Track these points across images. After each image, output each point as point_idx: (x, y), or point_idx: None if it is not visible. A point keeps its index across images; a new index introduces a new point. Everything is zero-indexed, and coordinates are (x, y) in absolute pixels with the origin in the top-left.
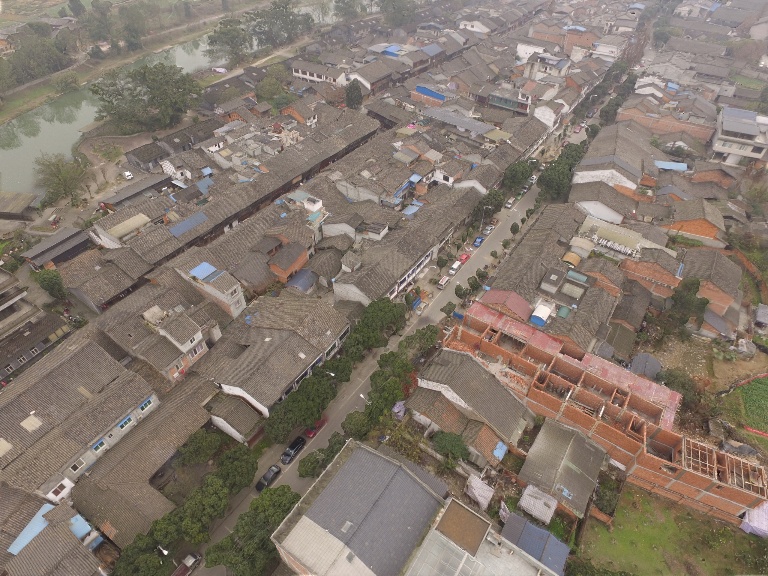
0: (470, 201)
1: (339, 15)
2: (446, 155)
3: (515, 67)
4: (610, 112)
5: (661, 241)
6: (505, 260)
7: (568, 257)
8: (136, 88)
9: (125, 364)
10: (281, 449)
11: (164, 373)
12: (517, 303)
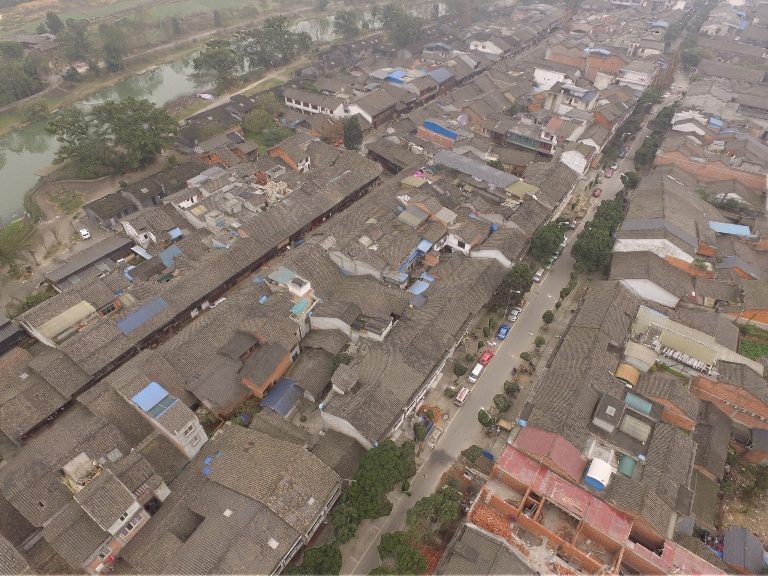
0: (492, 278)
1: (339, 32)
2: (461, 214)
3: (533, 95)
4: (648, 155)
5: (731, 336)
6: (542, 375)
7: (623, 372)
8: (103, 124)
9: (34, 543)
10: None
11: None
12: (565, 454)
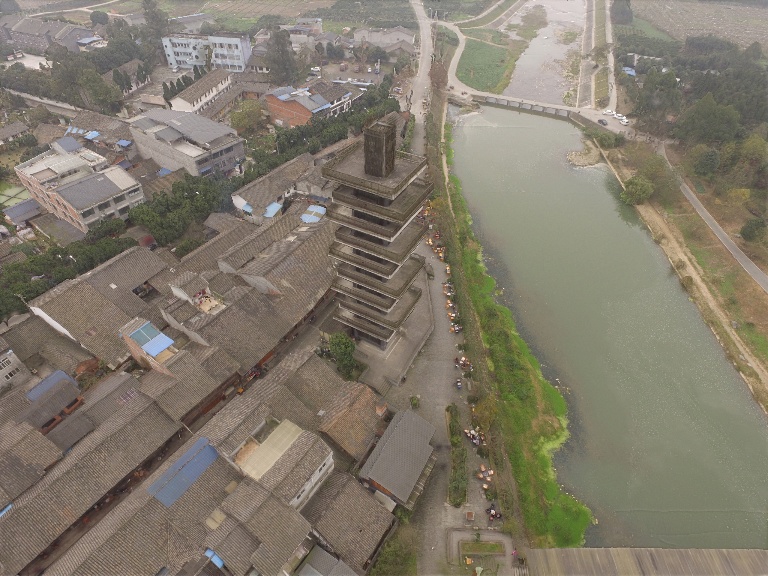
0: None
1: None
2: None
3: None
4: None
5: None
6: None
7: None
8: None
9: None
10: None
11: None
12: None
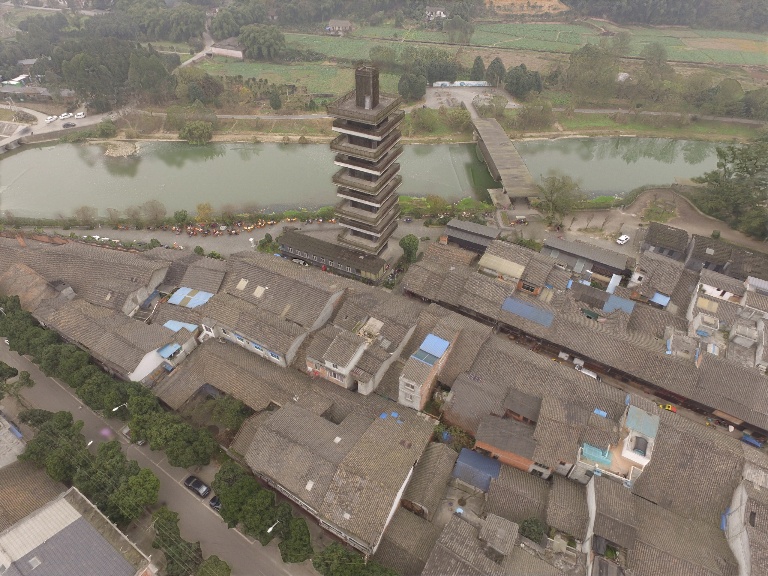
0: None
1: None
2: None
3: None
4: None
5: None
6: None
7: None
8: None
9: None
10: None
11: None
12: None
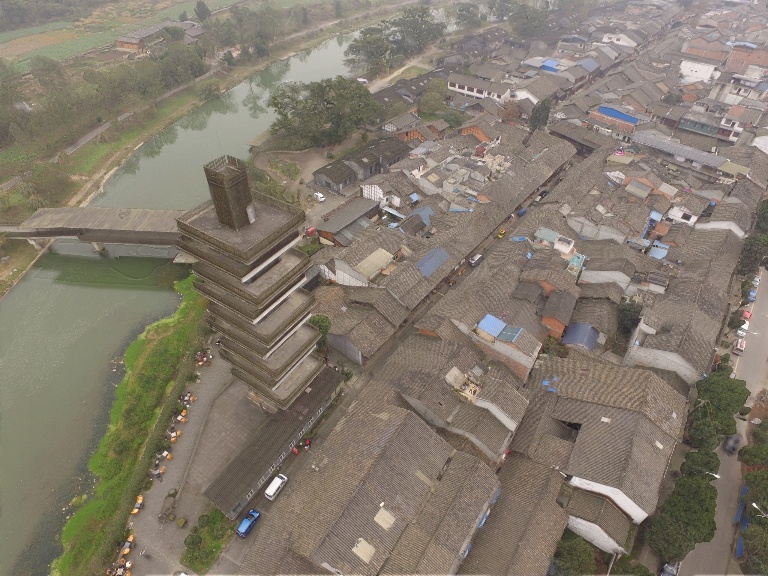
0: (733, 247)
1: (461, 24)
2: (678, 189)
3: (684, 86)
4: None
5: None
6: None
7: None
8: (307, 101)
9: None
10: (653, 563)
11: (493, 454)
12: None
